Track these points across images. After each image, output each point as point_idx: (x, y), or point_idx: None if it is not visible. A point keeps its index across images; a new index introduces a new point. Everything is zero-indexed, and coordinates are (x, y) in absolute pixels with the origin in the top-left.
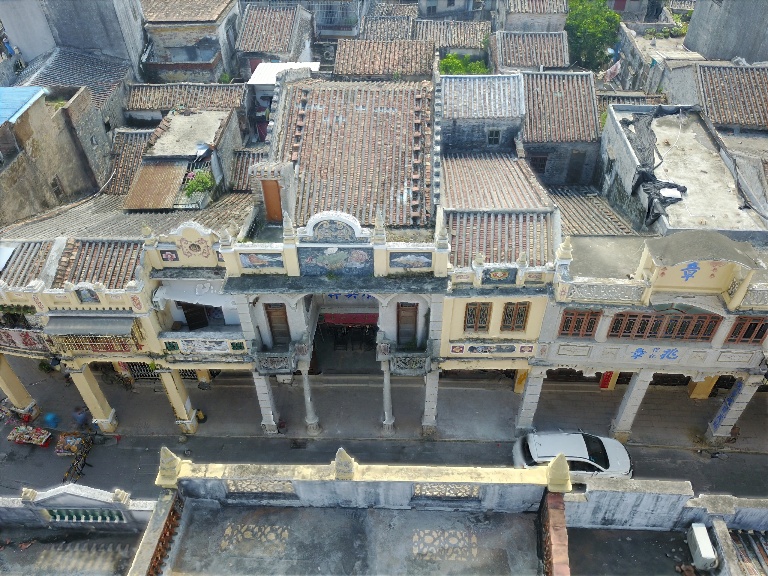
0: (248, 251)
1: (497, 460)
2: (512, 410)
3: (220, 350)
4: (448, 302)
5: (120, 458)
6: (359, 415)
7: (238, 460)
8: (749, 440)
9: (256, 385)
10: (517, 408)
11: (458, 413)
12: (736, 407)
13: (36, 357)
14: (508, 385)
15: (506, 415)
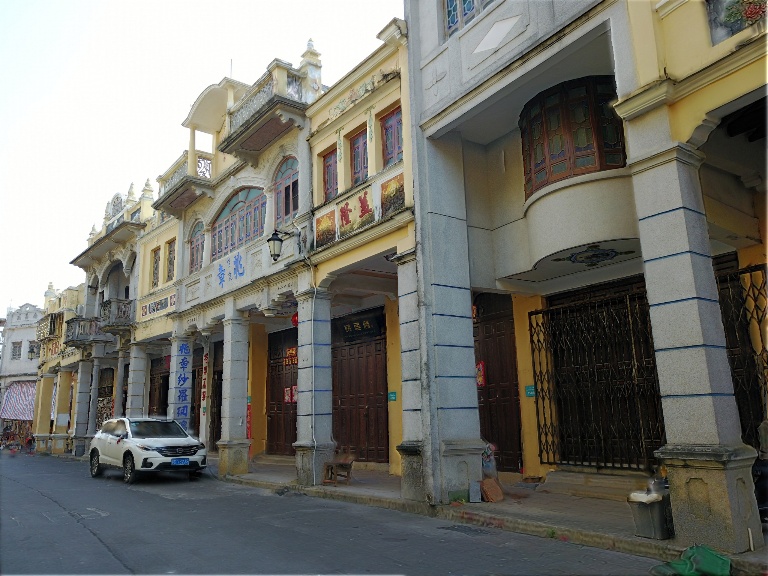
0: None
1: None
2: None
3: None
4: None
5: (12, 455)
6: None
7: (34, 459)
8: (363, 489)
9: None
10: (214, 464)
11: None
12: (302, 360)
13: None
14: None
15: None
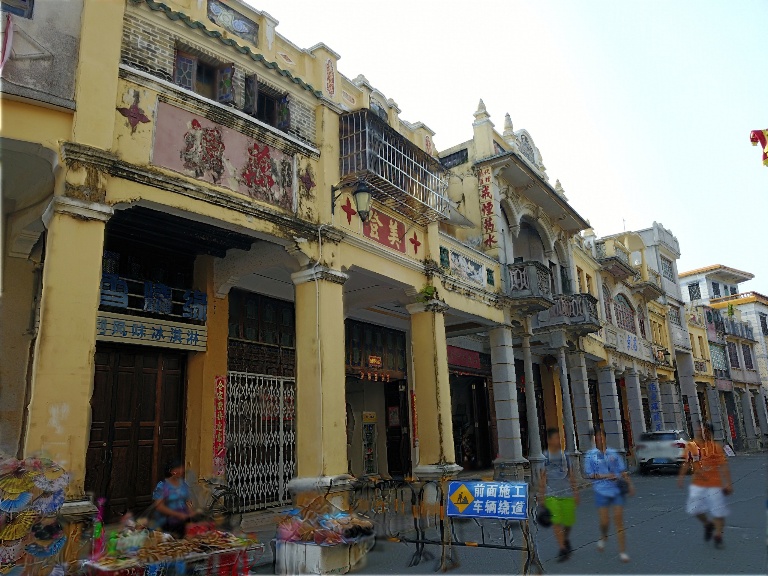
0: (495, 137)
1: None
2: None
3: (477, 283)
4: None
5: None
6: None
7: None
8: None
9: (507, 361)
10: None
11: None
12: None
13: (256, 225)
14: (553, 469)
15: None
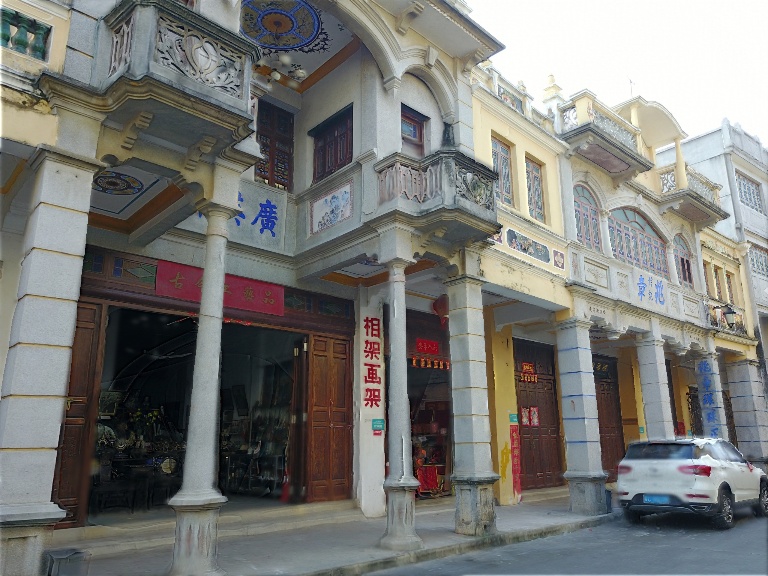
0: None
1: (626, 533)
2: (533, 511)
3: None
4: (476, 110)
5: None
6: (293, 551)
7: None
8: None
9: (38, 243)
10: None
11: None
12: (719, 402)
13: None
14: None
15: (537, 513)
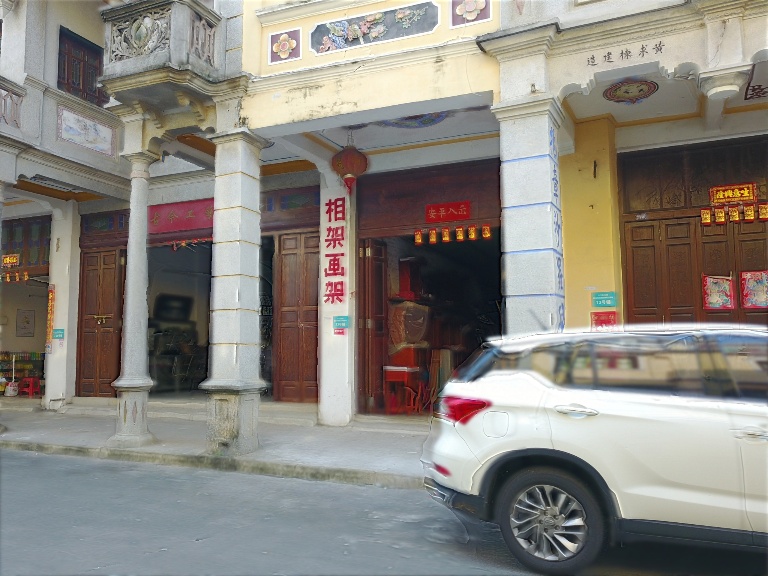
0: None
1: (392, 508)
2: None
3: None
4: None
5: None
6: (110, 432)
7: None
8: None
9: None
10: None
11: (354, 447)
12: None
13: None
14: None
15: None
